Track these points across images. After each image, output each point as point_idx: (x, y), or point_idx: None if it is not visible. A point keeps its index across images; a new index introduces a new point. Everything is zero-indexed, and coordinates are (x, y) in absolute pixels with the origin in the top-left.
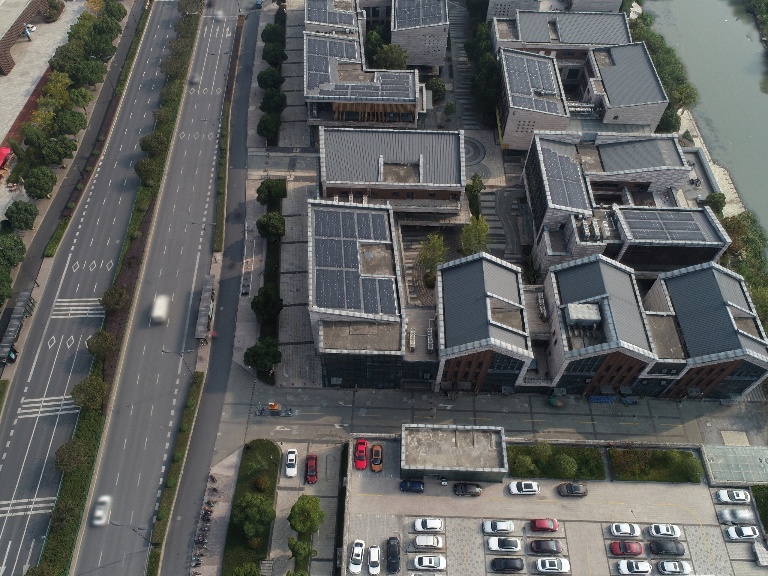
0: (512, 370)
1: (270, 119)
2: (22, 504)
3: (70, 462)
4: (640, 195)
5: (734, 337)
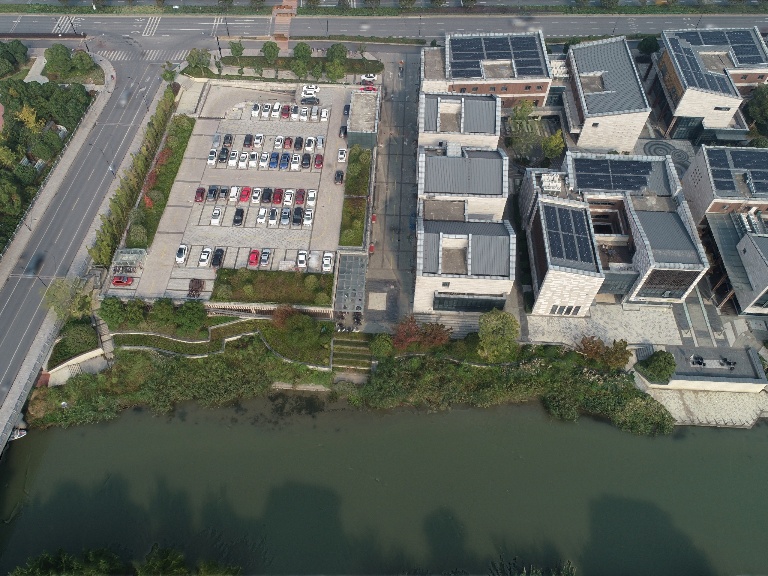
0: None
1: (650, 38)
2: (353, 0)
3: (368, 0)
4: (625, 252)
5: (436, 232)
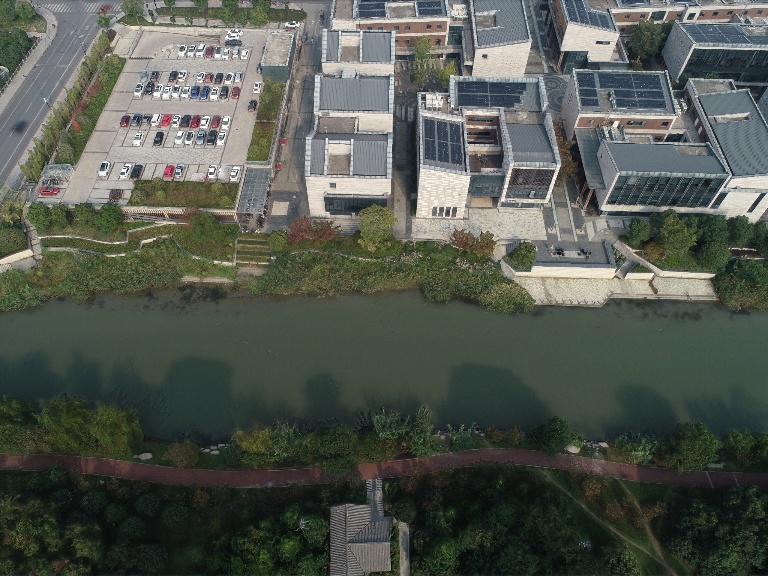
0: None
1: None
2: None
3: None
4: (497, 160)
5: None
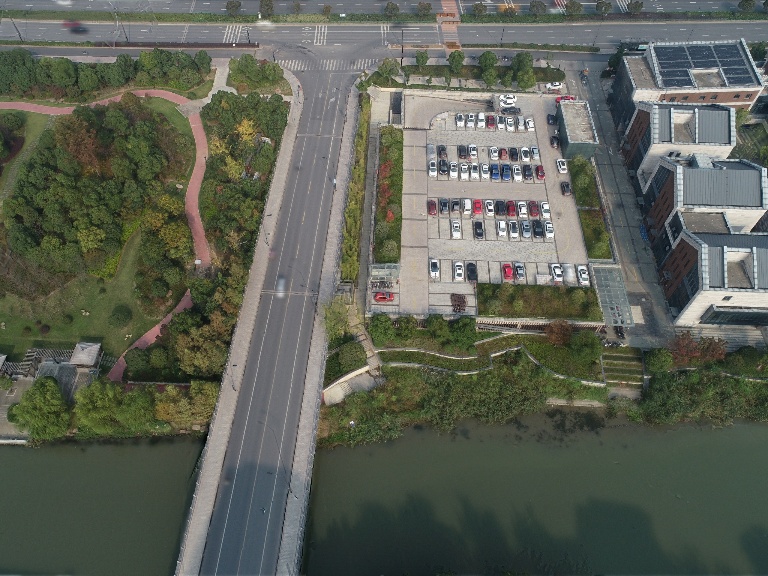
0: (644, 152)
1: None
2: None
3: (535, 7)
4: None
5: (718, 246)
